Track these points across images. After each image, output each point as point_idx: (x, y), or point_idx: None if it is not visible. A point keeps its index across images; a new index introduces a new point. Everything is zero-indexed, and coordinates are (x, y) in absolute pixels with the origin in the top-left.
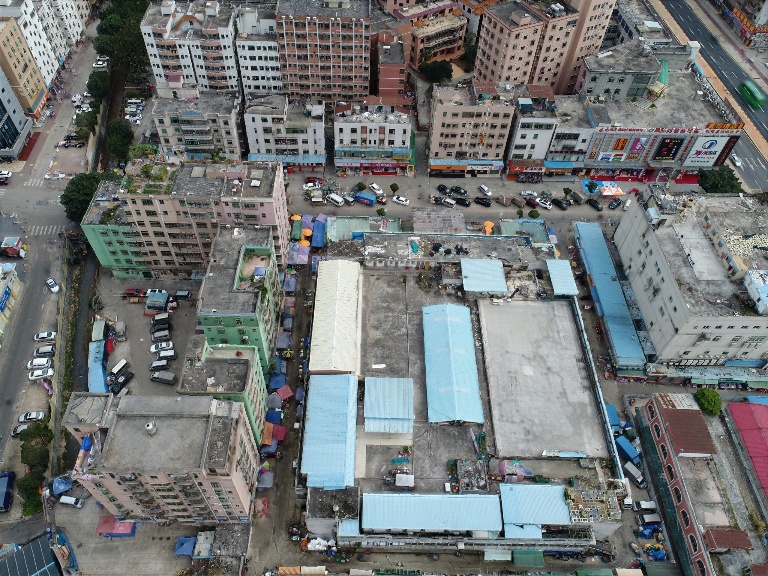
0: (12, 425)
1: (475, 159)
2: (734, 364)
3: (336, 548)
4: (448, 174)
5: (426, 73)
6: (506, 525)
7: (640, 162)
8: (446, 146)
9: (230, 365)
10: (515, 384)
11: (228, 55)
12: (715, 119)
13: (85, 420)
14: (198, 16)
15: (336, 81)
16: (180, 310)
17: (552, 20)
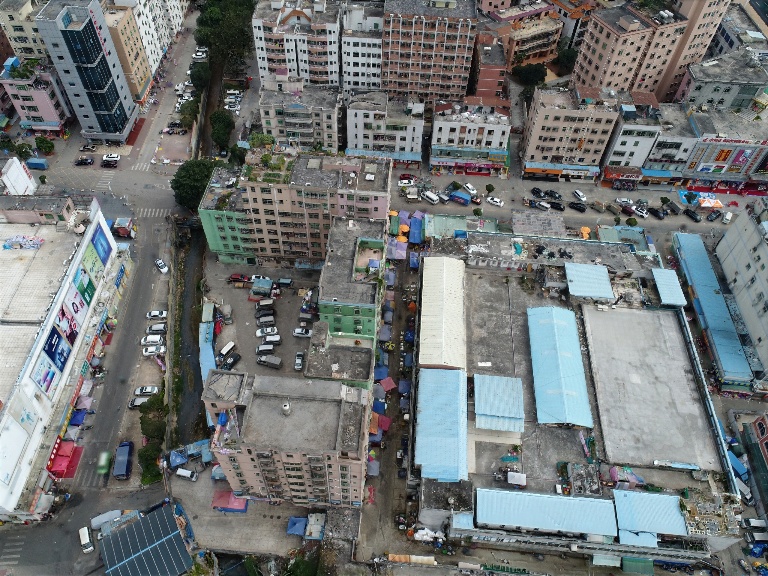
0: (128, 397)
1: (570, 164)
2: None
3: (442, 540)
4: (541, 177)
5: (520, 76)
6: (621, 531)
7: (741, 175)
8: (543, 149)
9: (353, 353)
10: (623, 391)
11: (332, 51)
12: None
13: (223, 396)
14: (306, 11)
15: (435, 80)
16: (283, 297)
17: (661, 27)
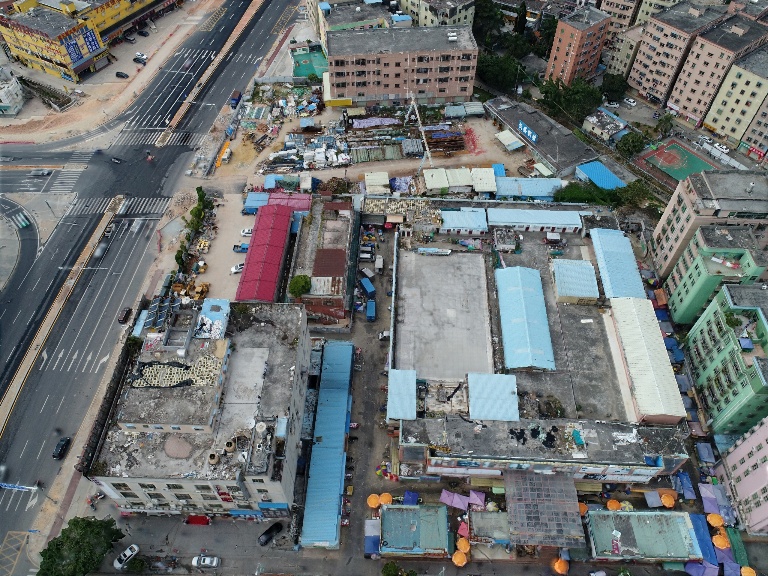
0: None
1: None
2: None
3: None
4: None
5: None
6: None
7: None
8: None
9: None
10: None
11: None
12: None
13: None
14: None
15: None
16: None
17: None
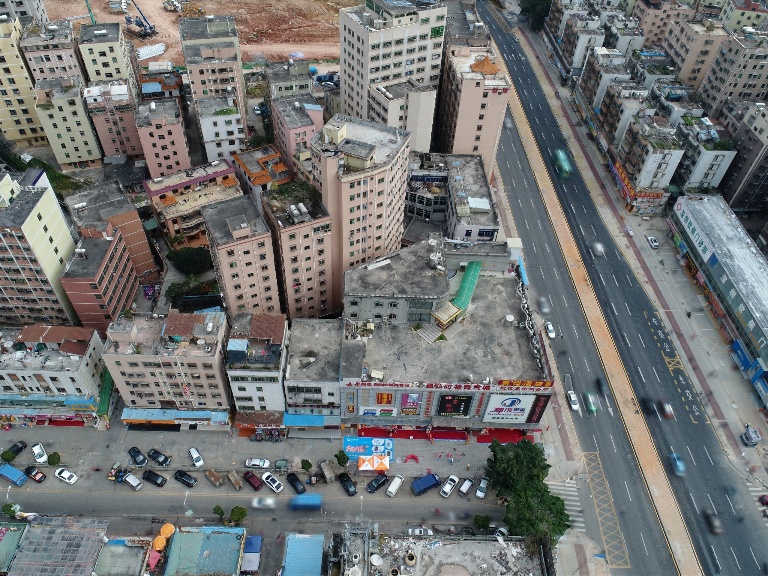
0: None
1: (191, 407)
2: None
3: None
4: (157, 424)
5: (174, 264)
6: None
7: (422, 416)
8: (140, 395)
9: None
10: None
11: None
12: (524, 361)
13: None
14: None
15: (11, 293)
16: None
17: (285, 229)
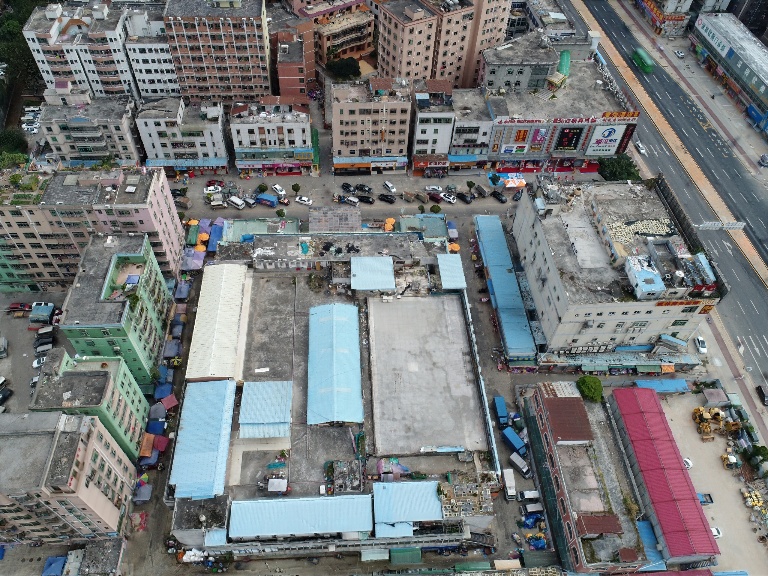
0: None
1: (379, 156)
2: (624, 349)
3: (213, 558)
4: (354, 172)
5: (333, 71)
6: (377, 524)
7: (543, 153)
8: (348, 144)
9: (89, 378)
10: (398, 381)
11: (119, 59)
12: (614, 108)
13: None
14: (86, 20)
15: (235, 82)
16: None
17: (446, 14)
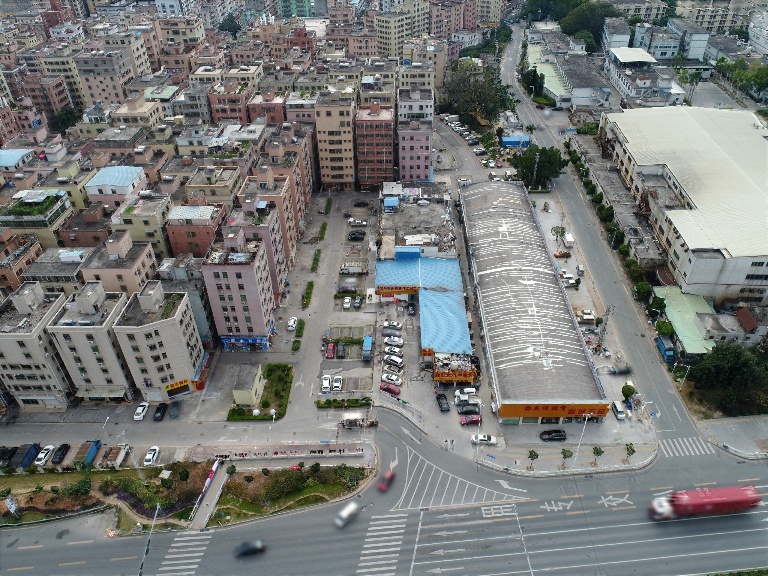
0: None
1: None
2: None
3: None
4: None
5: None
6: None
7: None
8: None
9: None
10: None
11: None
12: None
13: None
14: None
15: (203, 1)
16: None
17: None
